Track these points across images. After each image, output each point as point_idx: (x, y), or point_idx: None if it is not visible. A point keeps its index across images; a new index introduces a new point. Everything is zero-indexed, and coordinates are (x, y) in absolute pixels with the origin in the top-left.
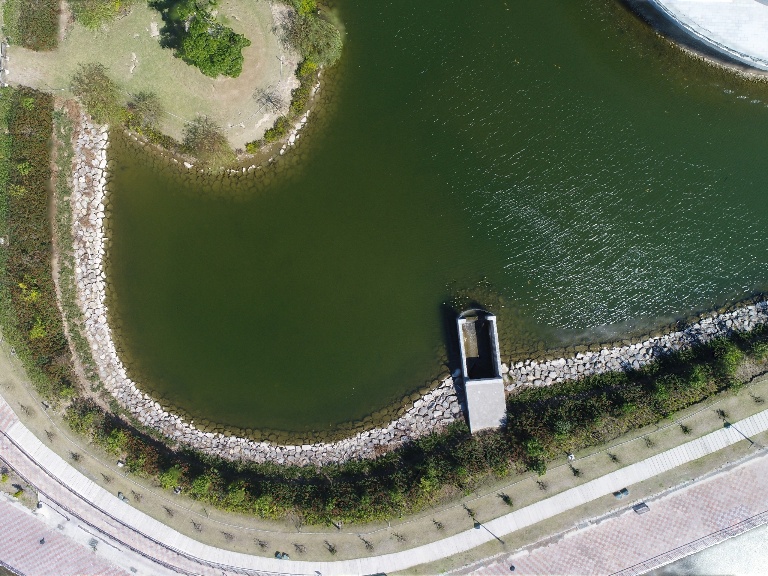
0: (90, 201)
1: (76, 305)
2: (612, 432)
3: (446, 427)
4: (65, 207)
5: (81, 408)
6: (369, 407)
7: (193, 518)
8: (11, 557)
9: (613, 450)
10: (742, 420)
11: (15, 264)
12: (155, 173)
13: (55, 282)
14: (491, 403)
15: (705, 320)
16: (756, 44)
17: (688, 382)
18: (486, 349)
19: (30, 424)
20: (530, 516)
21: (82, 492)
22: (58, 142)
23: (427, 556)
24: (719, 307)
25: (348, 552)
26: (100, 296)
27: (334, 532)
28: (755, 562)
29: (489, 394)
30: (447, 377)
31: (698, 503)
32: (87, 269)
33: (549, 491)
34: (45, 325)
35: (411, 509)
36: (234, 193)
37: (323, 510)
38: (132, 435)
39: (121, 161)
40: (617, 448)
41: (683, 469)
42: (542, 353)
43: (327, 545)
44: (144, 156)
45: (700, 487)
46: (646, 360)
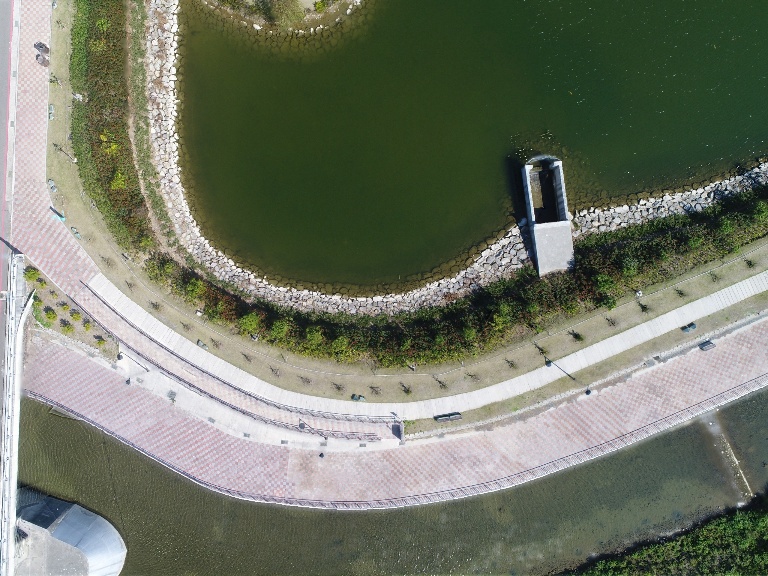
0: (162, 64)
1: (151, 164)
2: (678, 269)
3: (514, 272)
4: (139, 68)
5: (159, 260)
6: (437, 259)
7: (271, 364)
8: (91, 411)
9: (680, 286)
10: None
11: (94, 120)
12: (225, 37)
13: (131, 141)
14: (559, 246)
15: (764, 164)
16: None
17: (752, 216)
18: (550, 199)
19: (111, 275)
20: (600, 352)
21: (162, 341)
22: (132, 5)
23: (500, 394)
24: None
25: (423, 393)
26: (173, 157)
27: (409, 374)
28: None
29: (557, 237)
30: (513, 226)
31: (762, 339)
32: (161, 130)
33: (618, 327)
34: (124, 179)
35: (483, 349)
36: (302, 54)
37: (398, 351)
38: (209, 286)
39: (191, 26)
40: (684, 284)
41: (748, 302)
42: (606, 201)
43: (402, 387)
44: (214, 20)
45: (764, 323)
46: (708, 203)
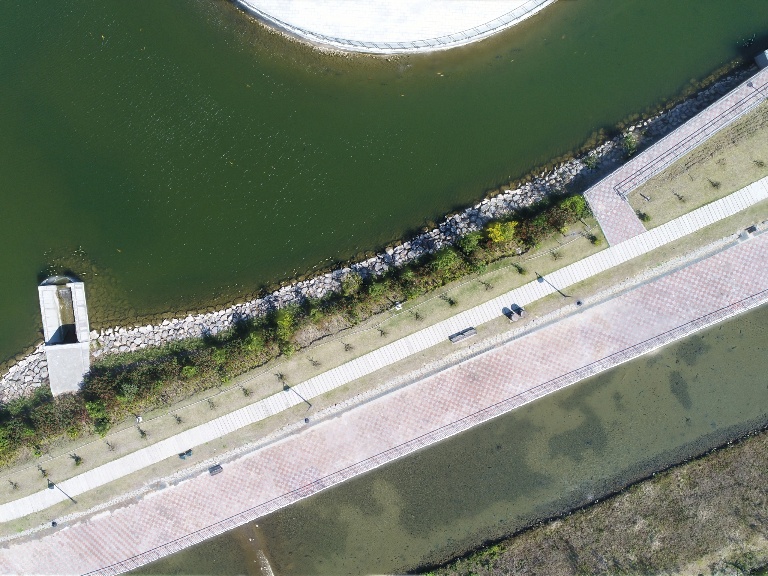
0: None
1: None
2: (179, 395)
3: (33, 391)
4: None
5: None
6: None
7: None
8: None
9: (179, 412)
10: (301, 383)
11: None
12: None
13: None
14: (70, 367)
15: (284, 288)
16: (306, 17)
17: None
18: None
19: None
20: (101, 477)
21: None
22: None
23: (4, 515)
24: (299, 275)
25: None
26: None
27: None
28: (354, 525)
29: (68, 359)
30: (41, 343)
31: (270, 465)
32: None
33: (118, 452)
34: None
35: None
36: None
37: None
38: None
39: None
40: (182, 410)
41: (245, 431)
42: (132, 320)
43: None
44: None
45: (272, 449)
46: (224, 326)
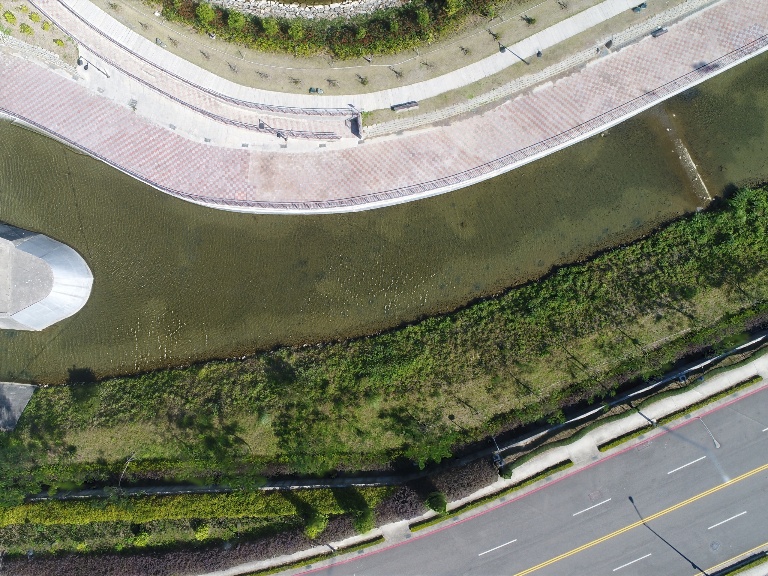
0: None
1: None
2: None
3: None
4: None
5: None
6: None
7: (229, 61)
8: (53, 122)
9: None
10: None
11: None
12: None
13: None
14: None
15: None
16: None
17: None
18: None
19: None
20: (553, 36)
21: (121, 40)
22: None
23: (456, 82)
24: None
25: (379, 83)
26: None
27: (365, 65)
28: None
29: None
30: None
31: (713, 25)
32: None
33: (570, 11)
34: None
35: (438, 39)
36: None
37: (354, 42)
38: None
39: None
40: None
41: None
42: None
43: (359, 78)
44: None
45: (715, 9)
46: None
